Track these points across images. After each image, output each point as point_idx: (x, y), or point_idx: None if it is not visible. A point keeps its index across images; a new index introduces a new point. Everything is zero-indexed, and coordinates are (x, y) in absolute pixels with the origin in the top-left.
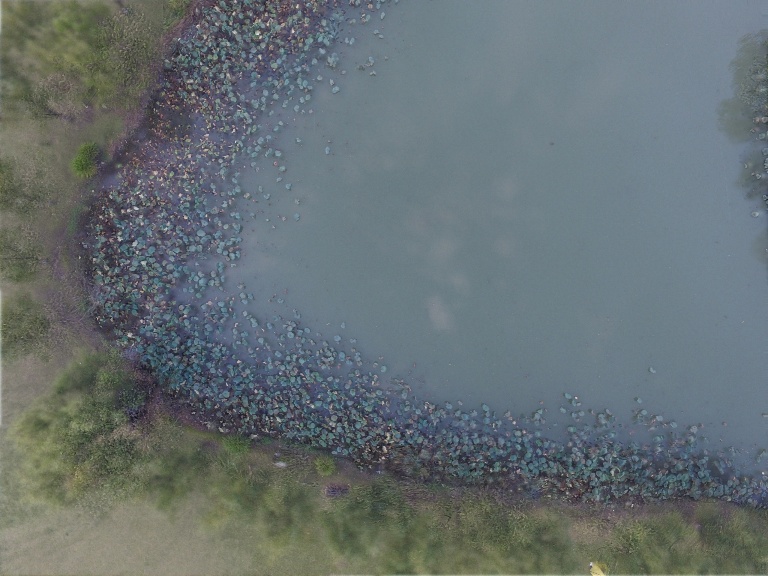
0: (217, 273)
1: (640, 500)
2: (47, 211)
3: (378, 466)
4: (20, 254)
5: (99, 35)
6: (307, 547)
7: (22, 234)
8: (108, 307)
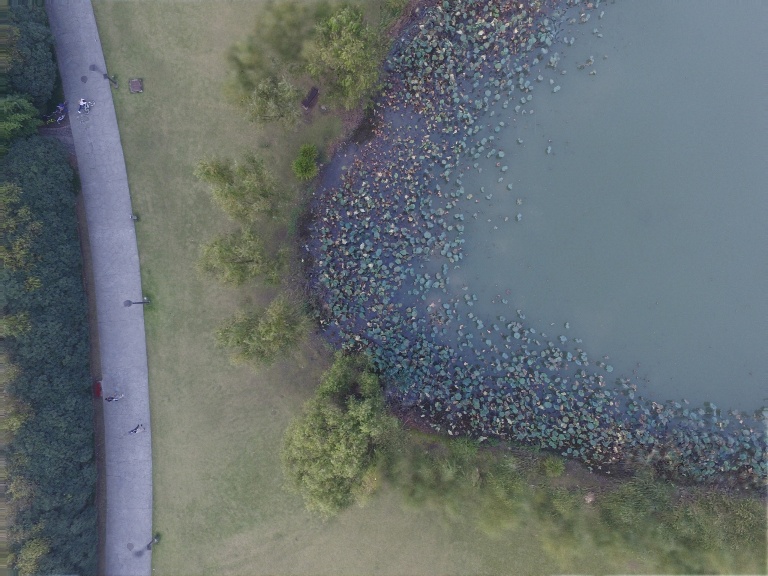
0: (441, 275)
1: None
2: (268, 214)
3: (608, 467)
4: (240, 258)
5: (317, 36)
6: (536, 549)
7: (242, 237)
8: (336, 310)
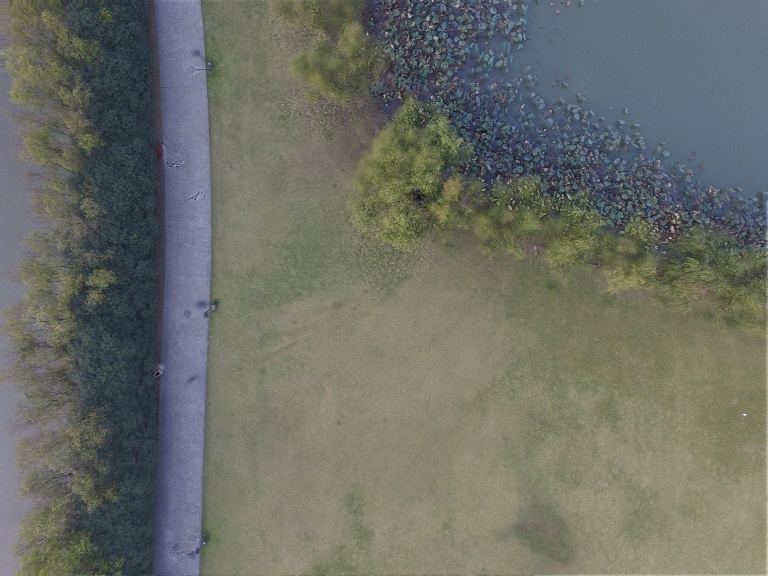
0: (505, 53)
1: None
2: None
3: (664, 247)
4: (304, 31)
5: None
6: (591, 327)
7: (307, 10)
8: (401, 81)
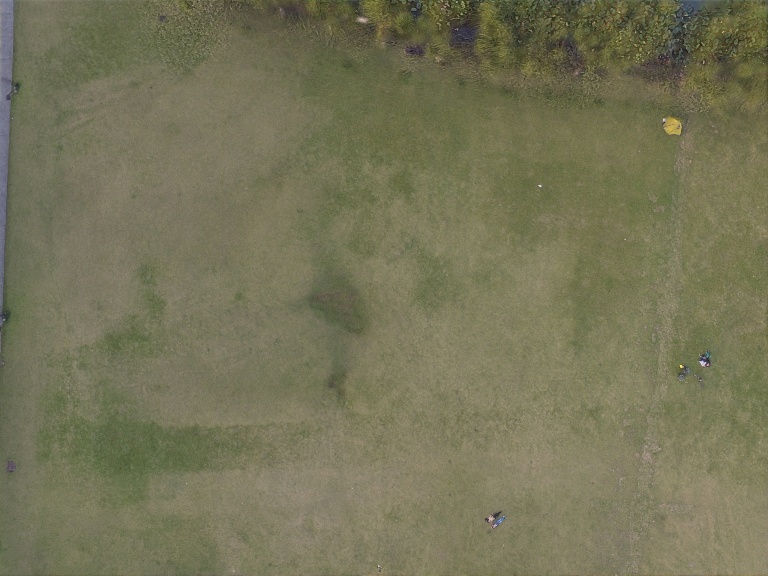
0: None
1: (711, 57)
2: None
3: (456, 23)
4: None
5: None
6: (386, 104)
7: None
8: None
